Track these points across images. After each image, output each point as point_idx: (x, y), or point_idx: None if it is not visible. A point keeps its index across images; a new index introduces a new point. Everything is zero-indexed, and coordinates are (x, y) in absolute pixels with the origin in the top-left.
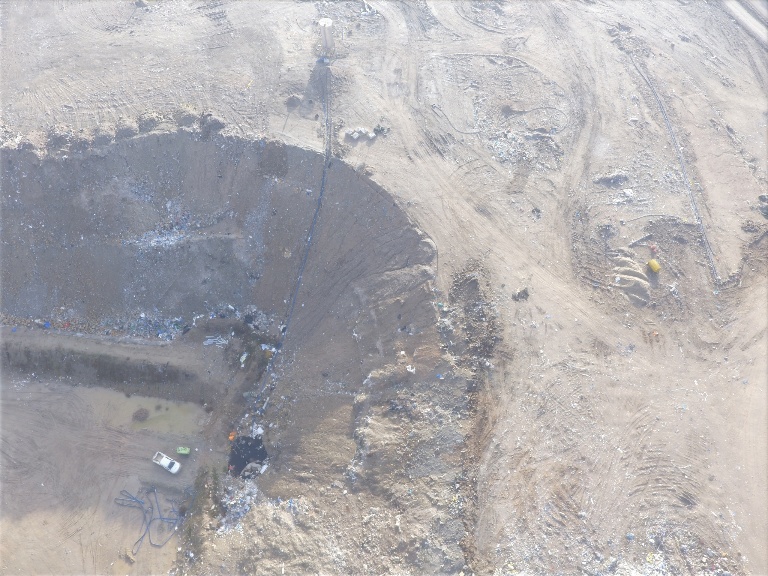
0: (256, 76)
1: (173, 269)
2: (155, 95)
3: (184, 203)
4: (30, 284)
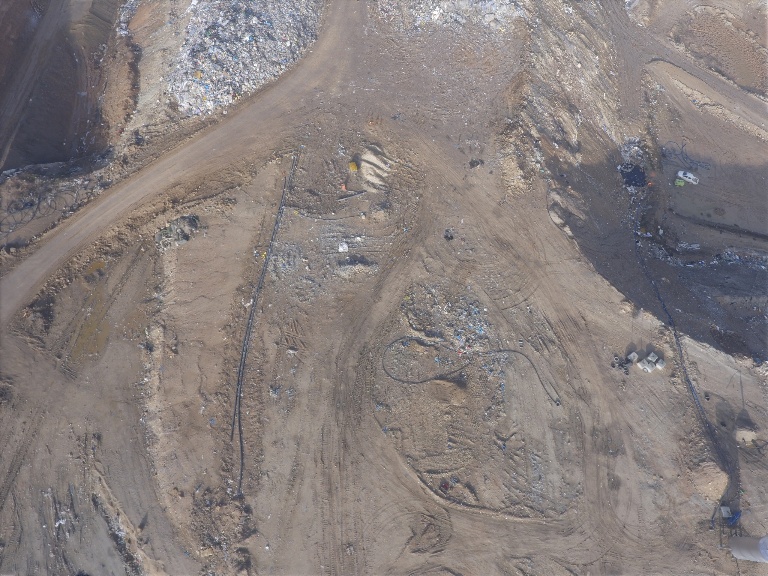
0: None
1: (765, 284)
2: None
3: None
4: None
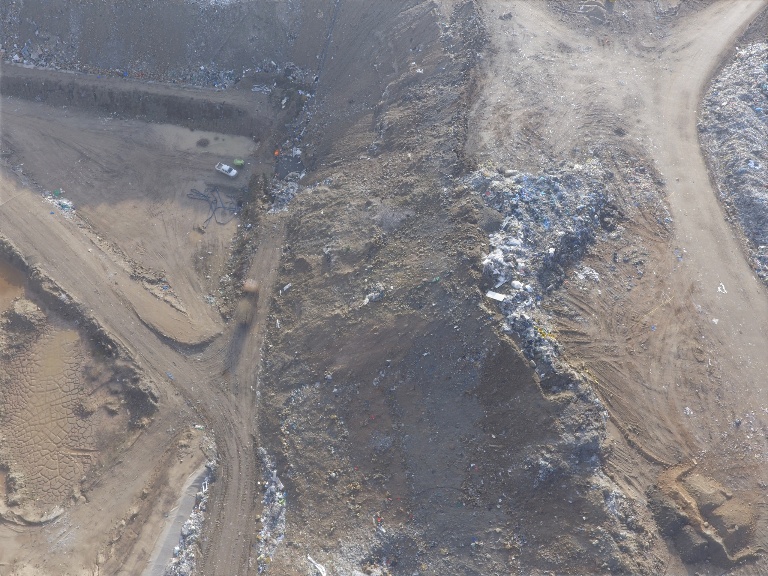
0: None
1: (227, 27)
2: None
3: None
4: (111, 40)
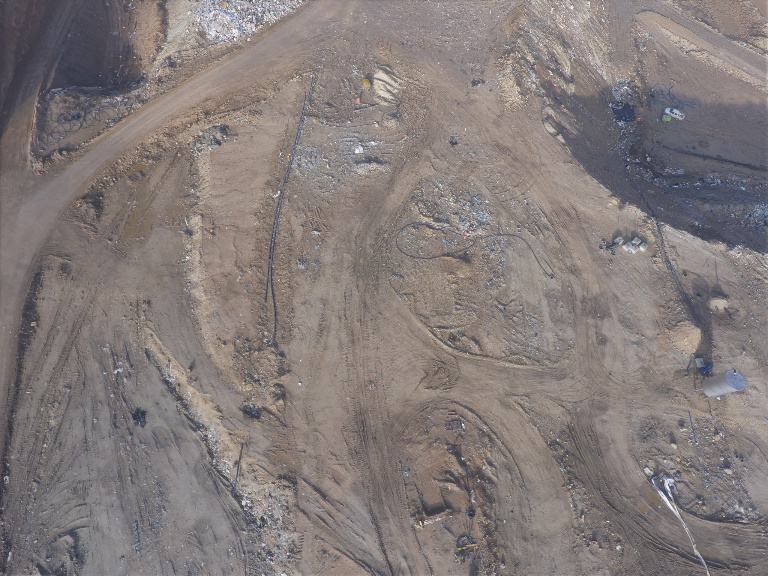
0: None
1: None
2: None
3: None
4: None
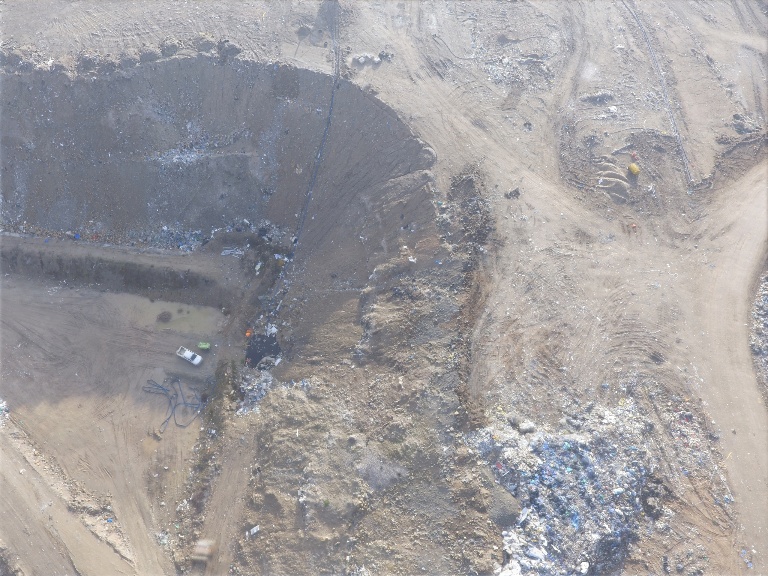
0: (269, 9)
1: (193, 184)
2: (175, 25)
3: (203, 124)
4: (61, 199)
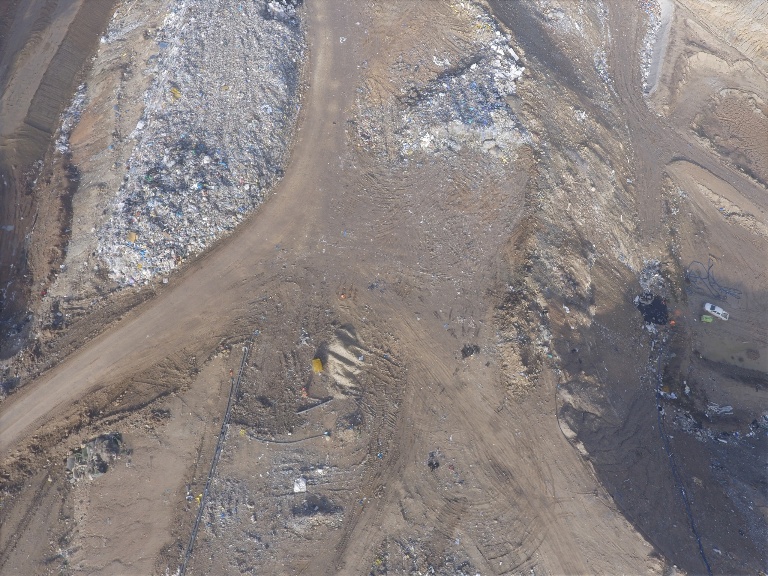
0: None
1: None
2: None
3: None
4: None
